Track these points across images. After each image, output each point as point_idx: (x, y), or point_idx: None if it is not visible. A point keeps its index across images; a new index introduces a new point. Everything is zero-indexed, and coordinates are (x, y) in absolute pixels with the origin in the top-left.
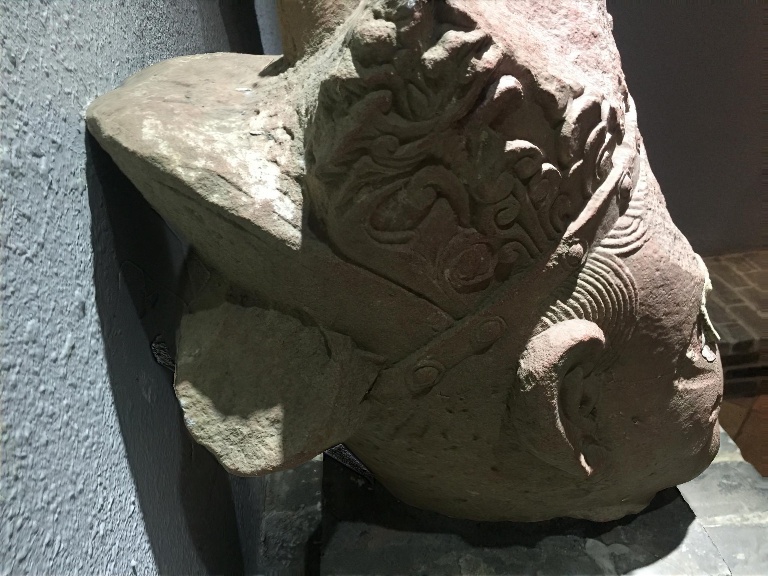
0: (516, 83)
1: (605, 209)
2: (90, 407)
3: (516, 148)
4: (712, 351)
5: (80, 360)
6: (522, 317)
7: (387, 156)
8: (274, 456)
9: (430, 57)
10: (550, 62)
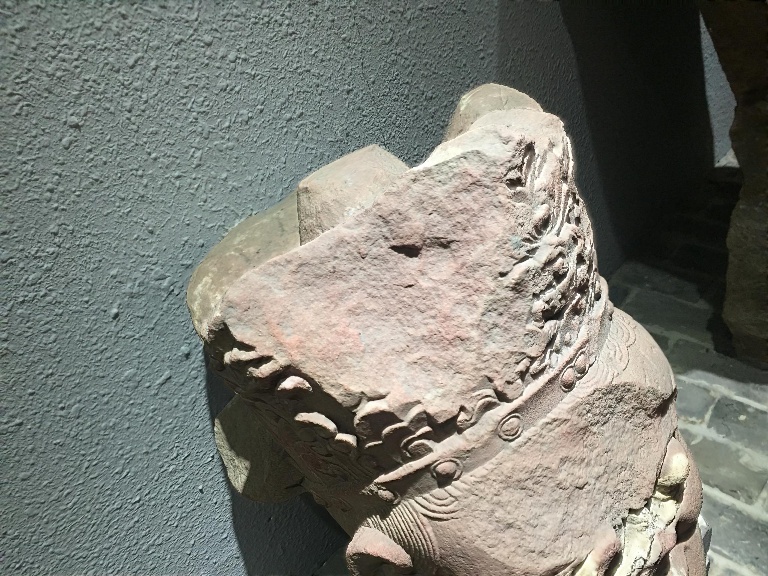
0: (300, 384)
1: (416, 478)
2: (179, 408)
3: (304, 420)
4: None
5: (175, 384)
6: (358, 509)
7: (232, 388)
8: (241, 486)
9: (225, 358)
10: (355, 369)
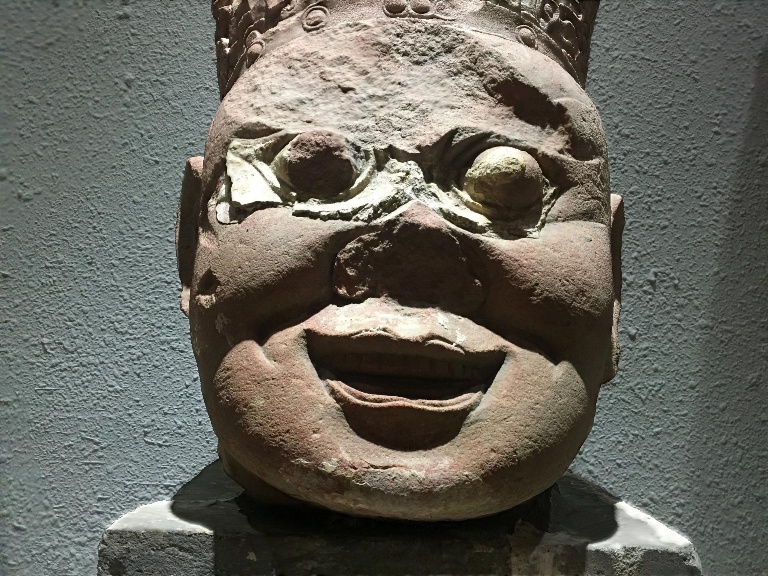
0: (227, 7)
1: None
2: None
3: None
4: (229, 214)
5: None
6: None
7: None
8: None
9: None
10: None
